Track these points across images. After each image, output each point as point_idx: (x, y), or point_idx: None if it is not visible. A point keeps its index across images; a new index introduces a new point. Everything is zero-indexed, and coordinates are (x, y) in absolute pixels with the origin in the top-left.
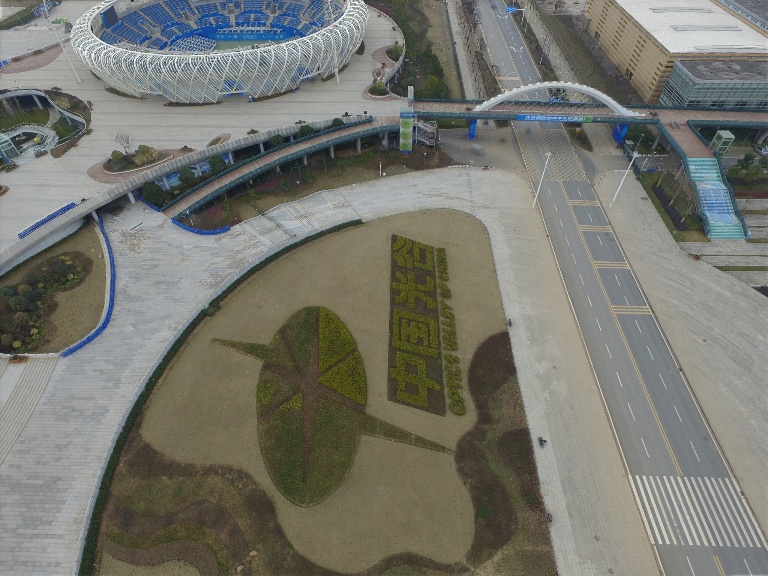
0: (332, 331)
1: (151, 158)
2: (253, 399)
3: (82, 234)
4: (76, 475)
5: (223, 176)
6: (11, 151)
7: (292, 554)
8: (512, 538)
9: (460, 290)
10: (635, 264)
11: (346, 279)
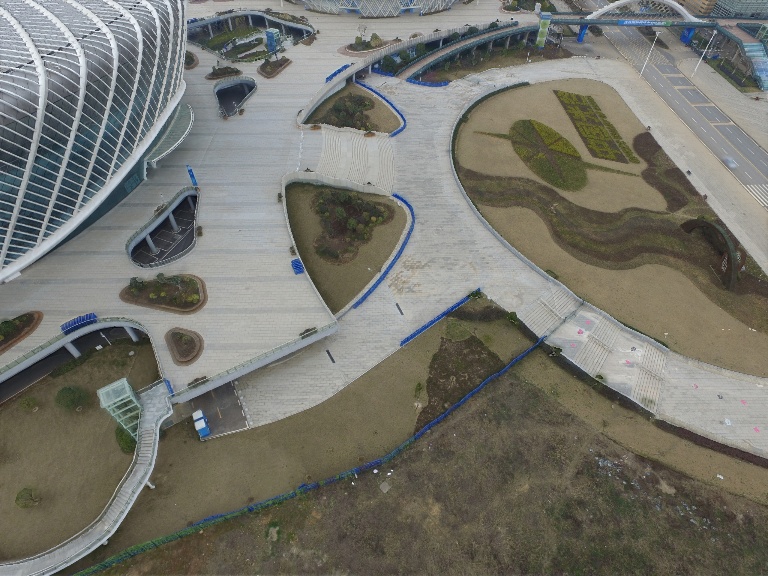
0: (544, 129)
1: (380, 43)
2: (516, 154)
3: (350, 88)
4: (441, 177)
5: (426, 57)
6: (277, 40)
7: (575, 206)
8: (688, 204)
9: (610, 115)
10: (717, 103)
11: (537, 109)
